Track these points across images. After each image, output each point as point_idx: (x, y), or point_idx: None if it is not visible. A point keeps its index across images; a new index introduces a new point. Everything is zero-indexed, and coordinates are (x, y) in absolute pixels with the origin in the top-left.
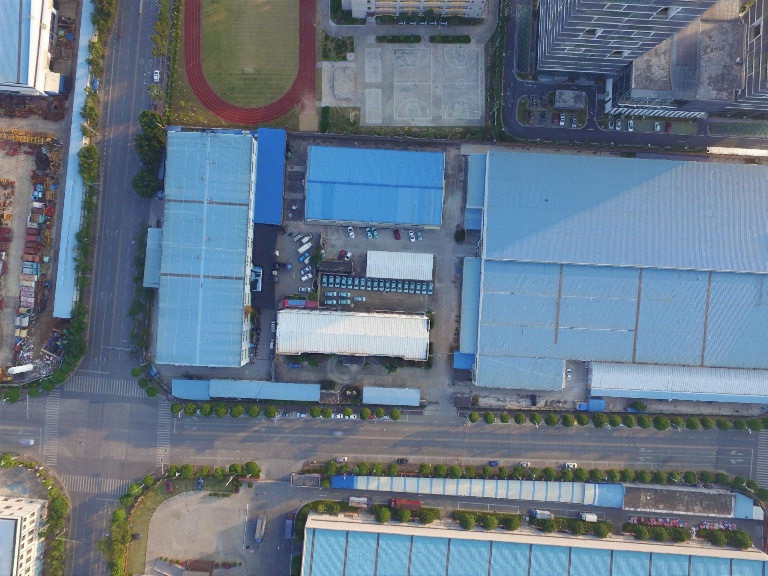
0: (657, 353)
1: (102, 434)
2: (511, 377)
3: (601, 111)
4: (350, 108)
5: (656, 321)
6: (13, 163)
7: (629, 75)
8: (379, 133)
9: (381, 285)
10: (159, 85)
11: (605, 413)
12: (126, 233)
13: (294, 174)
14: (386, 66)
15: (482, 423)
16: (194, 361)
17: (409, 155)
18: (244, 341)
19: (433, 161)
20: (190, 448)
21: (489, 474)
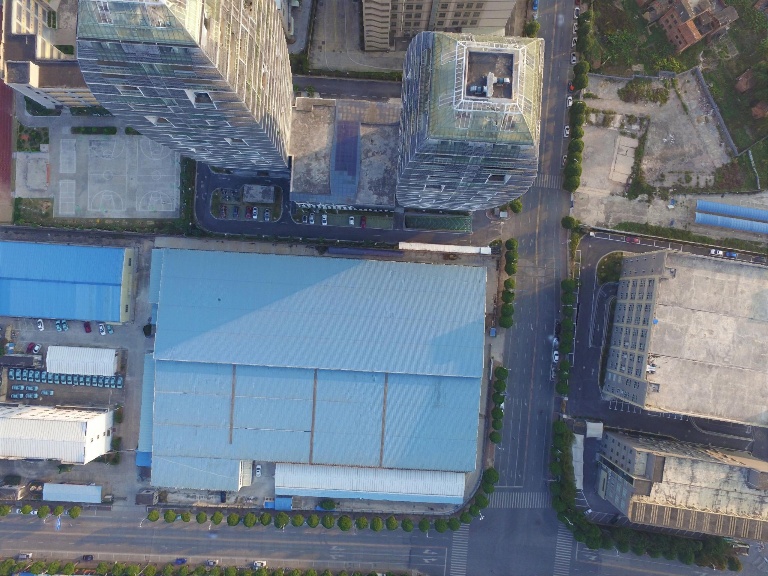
0: (334, 454)
1: None
2: (186, 477)
3: (296, 204)
4: (42, 199)
5: (332, 422)
6: None
7: None
8: (71, 225)
9: (68, 379)
10: None
11: (293, 511)
12: None
13: None
14: (81, 157)
15: None
16: None
17: (89, 251)
18: None
19: (113, 257)
20: None
21: (167, 574)
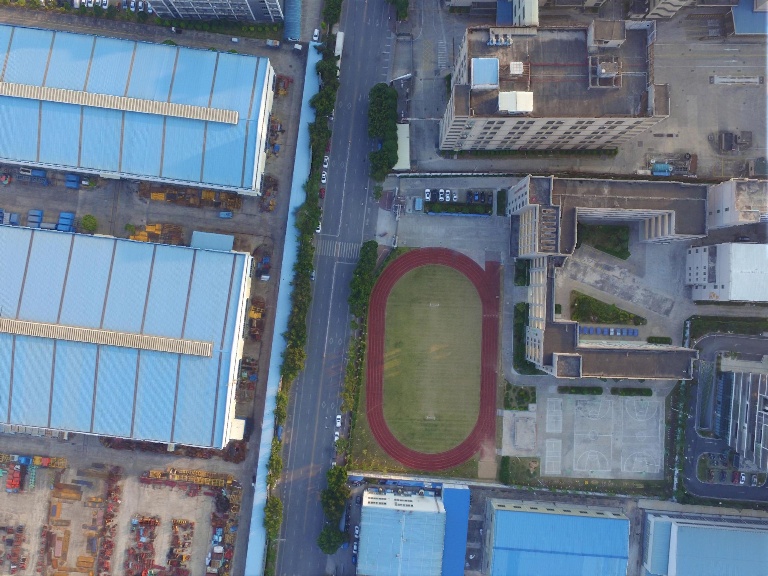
0: None
1: None
2: None
3: None
4: (530, 459)
5: None
6: (193, 504)
7: None
8: (559, 485)
9: None
10: (340, 429)
11: None
12: None
13: (472, 523)
14: (567, 417)
15: None
16: None
17: (594, 522)
18: None
19: (618, 529)
20: None
21: None
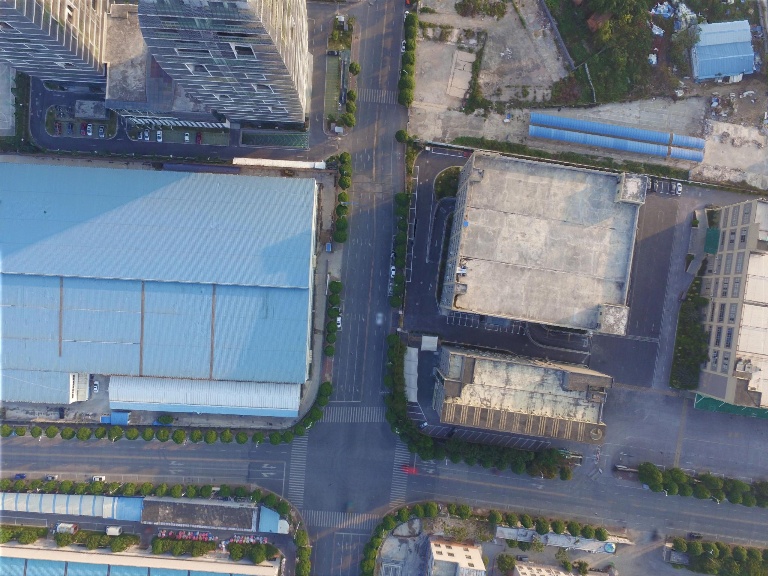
0: (164, 366)
1: None
2: (16, 390)
3: (131, 121)
4: None
5: (161, 334)
6: None
7: None
8: None
9: None
10: None
11: (130, 426)
12: None
13: None
14: None
15: (10, 436)
16: None
17: None
18: None
19: None
20: None
21: (2, 487)
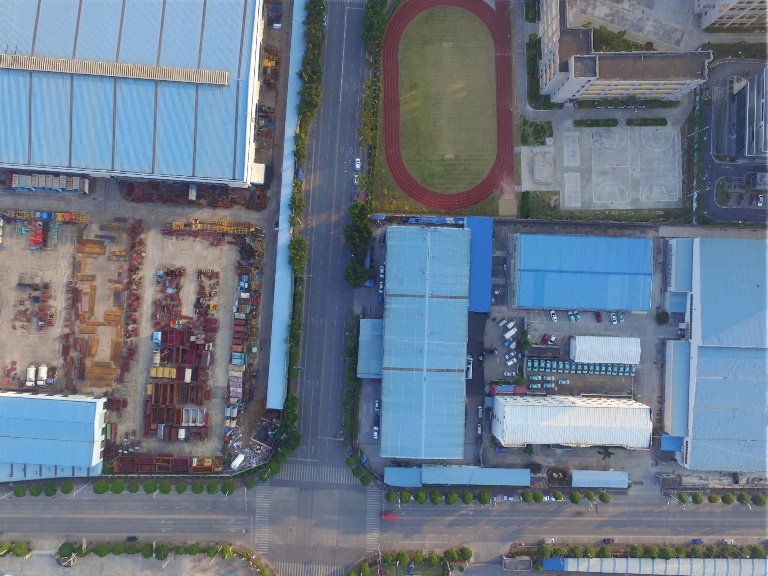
0: None
1: (312, 521)
2: (723, 460)
3: None
4: (550, 193)
5: None
6: (217, 253)
7: None
8: (579, 217)
9: (585, 368)
10: (360, 173)
11: None
12: (331, 321)
13: (496, 259)
14: (584, 150)
15: None
16: (419, 454)
17: (617, 242)
18: None
19: (641, 247)
20: (399, 533)
21: (699, 554)
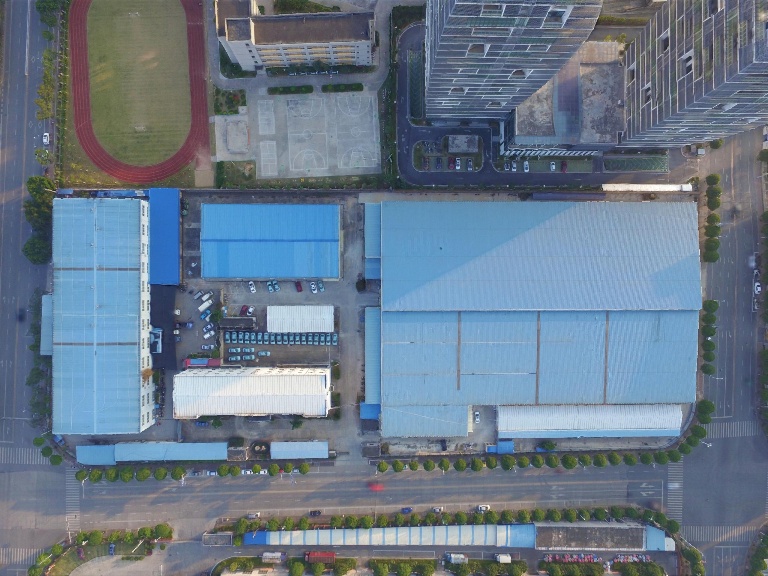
0: (559, 394)
1: (9, 504)
2: (416, 426)
3: (497, 153)
4: (245, 162)
5: (557, 362)
6: None
7: (513, 122)
8: (275, 186)
9: (285, 339)
10: (49, 148)
11: (514, 454)
12: (23, 299)
13: (192, 231)
14: (279, 118)
15: None
16: (92, 430)
17: (303, 208)
18: (144, 405)
19: (328, 213)
20: (100, 513)
21: (400, 523)
